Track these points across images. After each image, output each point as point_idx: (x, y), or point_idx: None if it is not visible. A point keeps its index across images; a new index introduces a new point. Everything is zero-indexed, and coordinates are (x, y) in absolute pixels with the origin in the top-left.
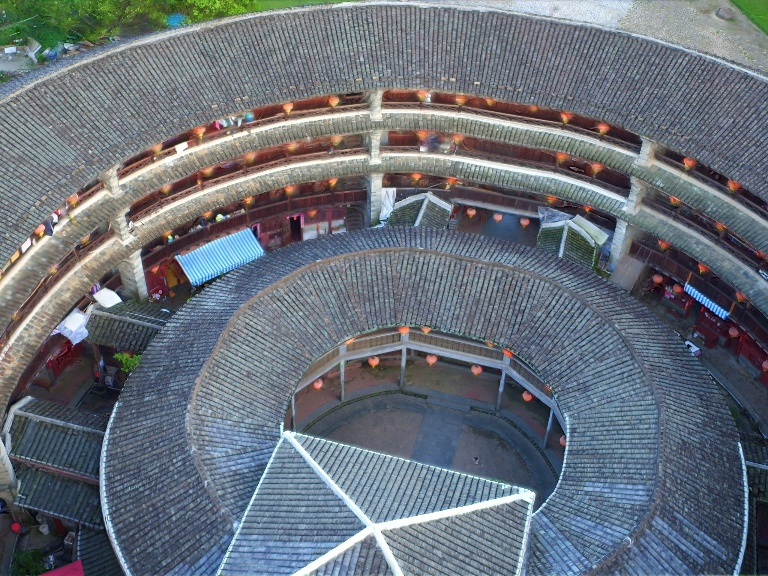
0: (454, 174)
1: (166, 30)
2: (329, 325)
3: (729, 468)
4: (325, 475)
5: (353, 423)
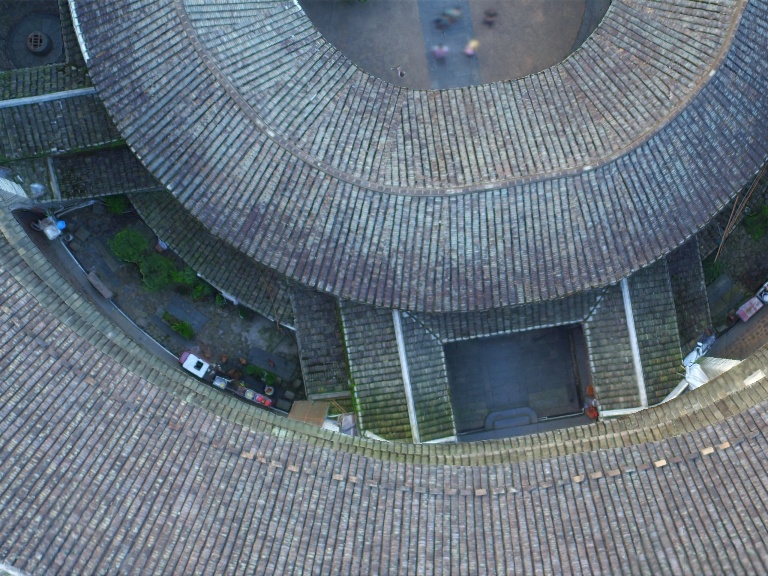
0: (623, 420)
1: None
2: (642, 7)
3: (93, 4)
4: None
5: (561, 59)
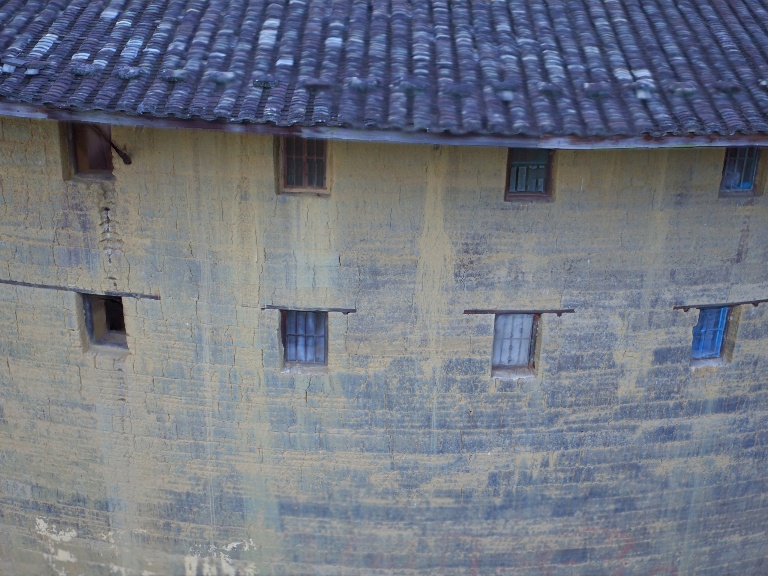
0: None
1: (731, 32)
2: None
3: None
4: None
5: None
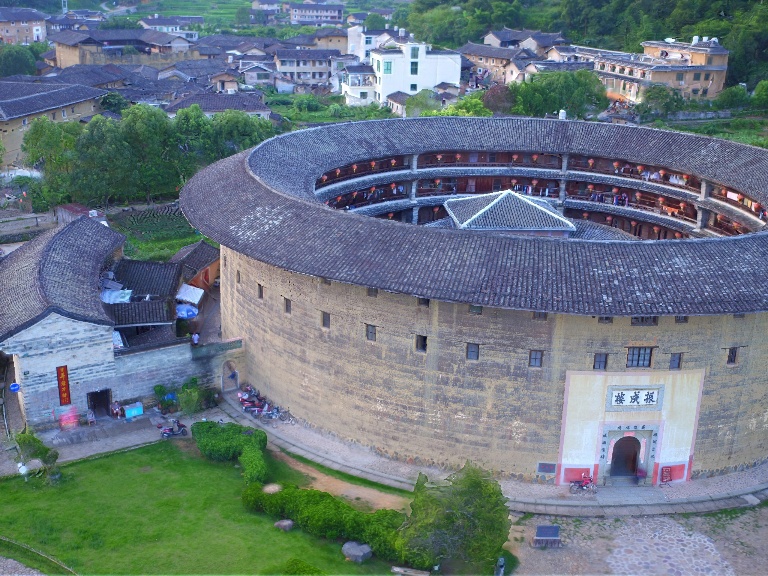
0: None
1: None
2: None
3: None
4: (541, 207)
5: None
